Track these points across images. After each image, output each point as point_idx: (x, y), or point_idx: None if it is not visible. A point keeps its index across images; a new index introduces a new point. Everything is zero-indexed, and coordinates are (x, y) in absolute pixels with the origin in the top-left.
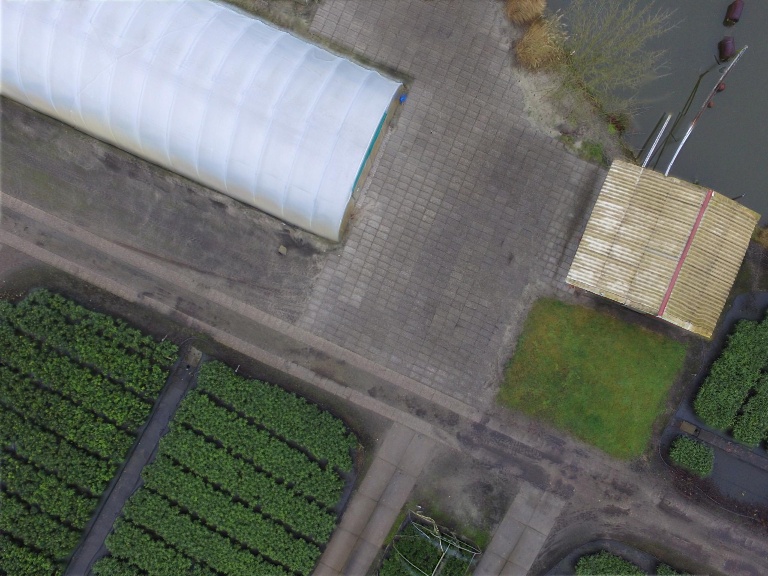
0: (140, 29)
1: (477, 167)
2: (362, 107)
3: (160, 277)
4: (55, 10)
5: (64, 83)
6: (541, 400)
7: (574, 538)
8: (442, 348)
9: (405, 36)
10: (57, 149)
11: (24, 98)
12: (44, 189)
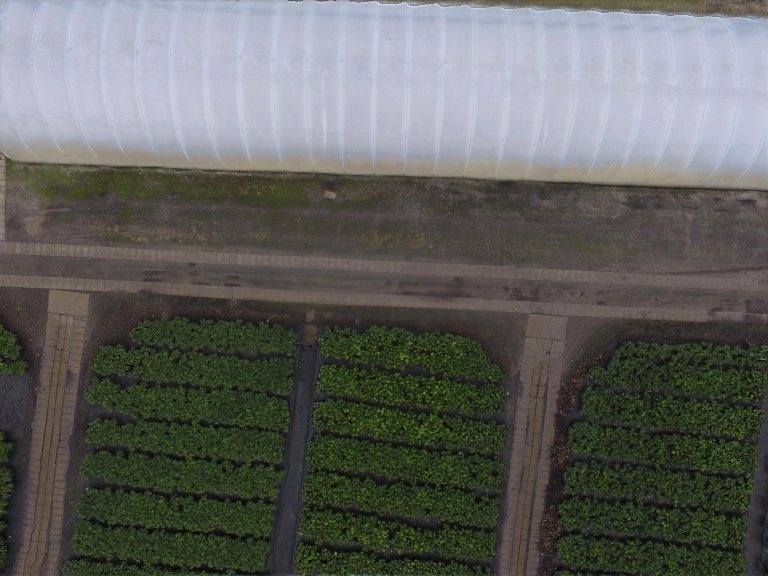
0: (686, 61)
1: None
2: None
3: (722, 289)
4: (603, 74)
5: (618, 140)
6: None
7: None
8: None
9: None
10: (580, 210)
11: (551, 172)
12: (584, 251)
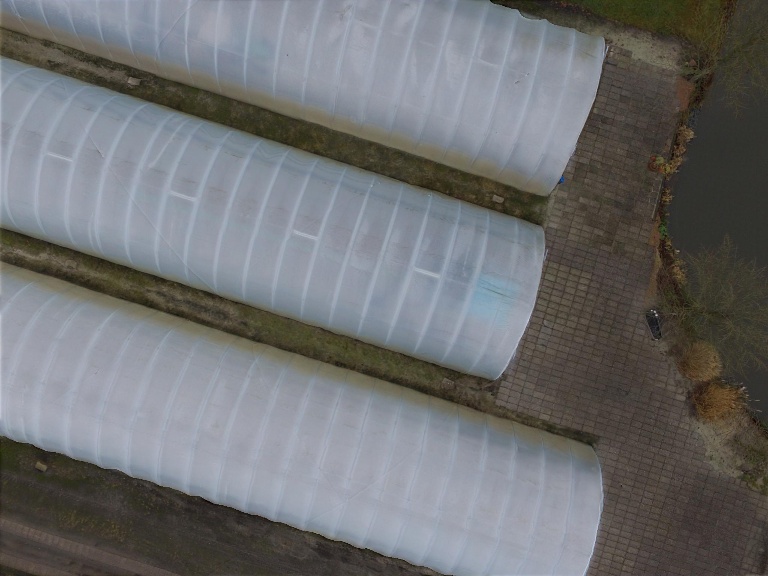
0: (366, 468)
1: (668, 514)
2: (579, 513)
3: None
4: (285, 461)
5: (293, 515)
6: None
7: None
8: None
9: (586, 397)
10: (271, 544)
11: None
12: None
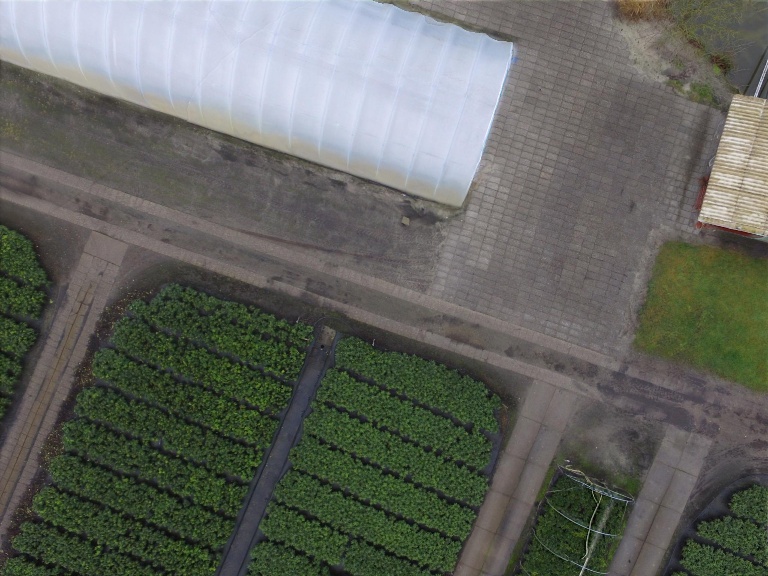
0: (259, 11)
1: (589, 119)
2: (485, 66)
3: (287, 260)
4: (173, 1)
5: (185, 74)
6: (678, 343)
7: (724, 476)
8: (574, 302)
9: None
10: (172, 144)
11: (139, 95)
12: (163, 185)
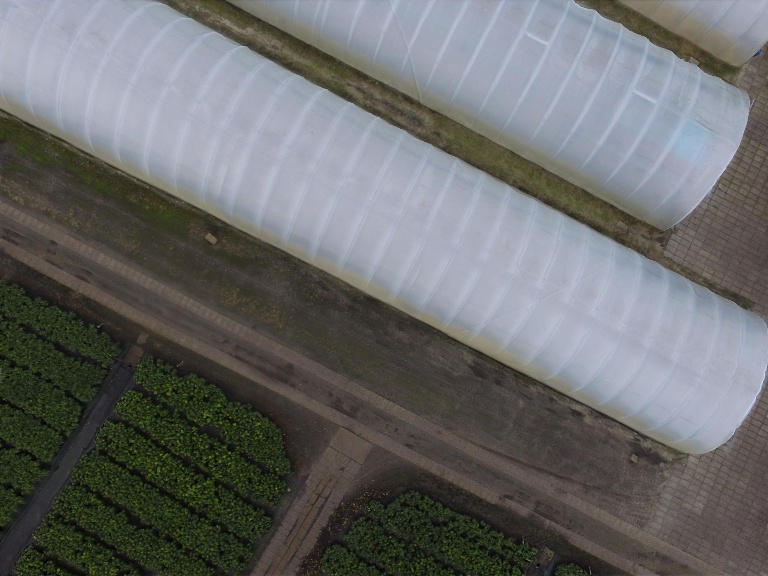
0: (561, 272)
1: None
2: (750, 351)
3: (521, 481)
4: (484, 250)
5: (476, 312)
6: None
7: None
8: None
9: (748, 263)
10: (429, 354)
11: (414, 311)
12: (416, 392)
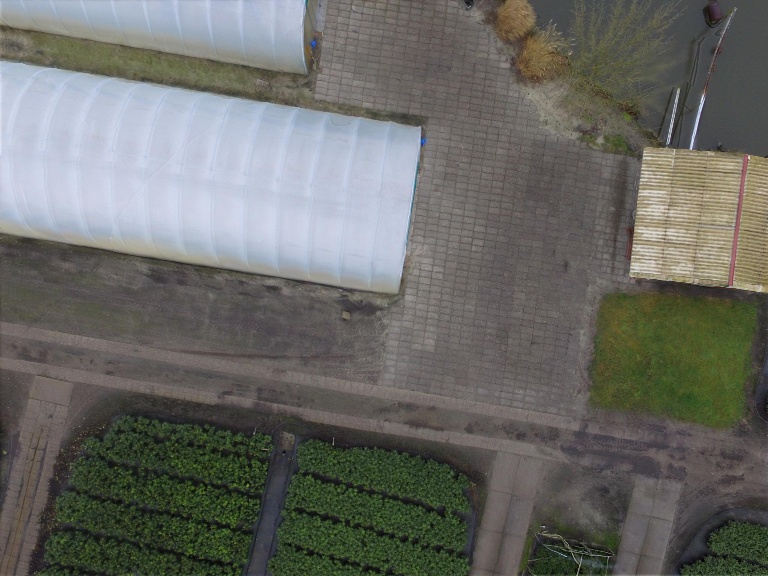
0: (162, 144)
1: (511, 186)
2: (395, 162)
3: (235, 373)
4: (75, 147)
5: (99, 214)
6: (632, 393)
7: (698, 516)
8: (524, 369)
9: (408, 79)
10: (102, 276)
11: (59, 237)
12: (99, 318)
